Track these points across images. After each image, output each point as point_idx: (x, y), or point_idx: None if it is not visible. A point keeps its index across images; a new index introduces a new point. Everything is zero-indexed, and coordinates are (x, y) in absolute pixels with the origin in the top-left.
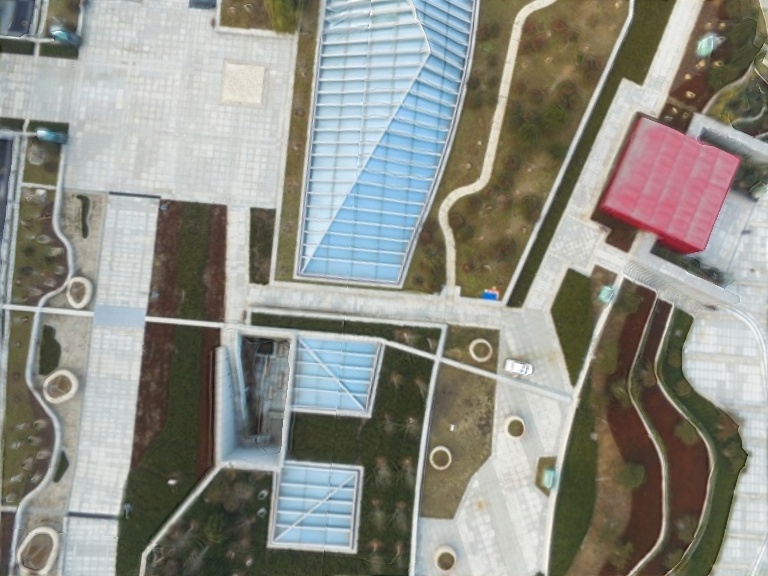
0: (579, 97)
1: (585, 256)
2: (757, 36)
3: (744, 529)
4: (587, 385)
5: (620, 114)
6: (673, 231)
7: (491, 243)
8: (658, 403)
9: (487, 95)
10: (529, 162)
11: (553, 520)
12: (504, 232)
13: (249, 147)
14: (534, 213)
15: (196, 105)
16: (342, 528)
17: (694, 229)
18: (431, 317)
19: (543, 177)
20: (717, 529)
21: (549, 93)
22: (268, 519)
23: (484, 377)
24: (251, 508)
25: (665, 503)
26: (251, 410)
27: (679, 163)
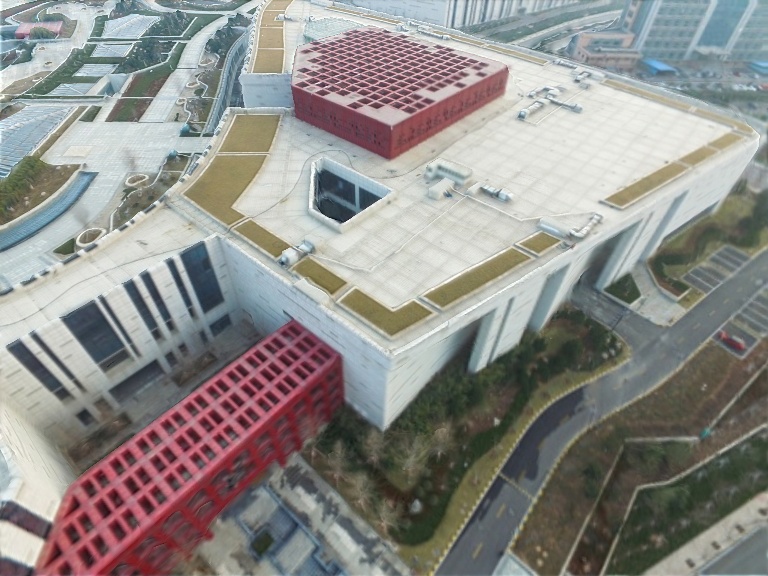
0: None
1: None
2: None
3: None
4: None
5: None
6: None
7: None
8: None
9: None
10: None
11: None
12: None
13: None
14: None
15: None
16: (87, 67)
17: None
18: None
19: None
20: None
21: None
22: None
23: None
24: None
25: None
26: None
27: None
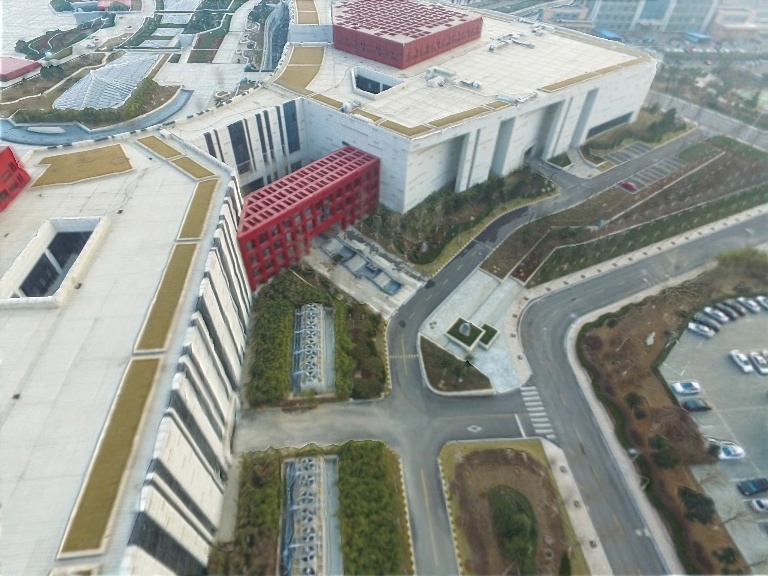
0: None
1: None
2: None
3: None
4: None
5: None
6: None
7: None
8: None
9: None
10: None
11: None
12: None
13: None
14: None
15: None
16: None
17: None
18: None
19: None
20: None
21: None
22: None
23: None
24: None
25: None
26: None
27: None
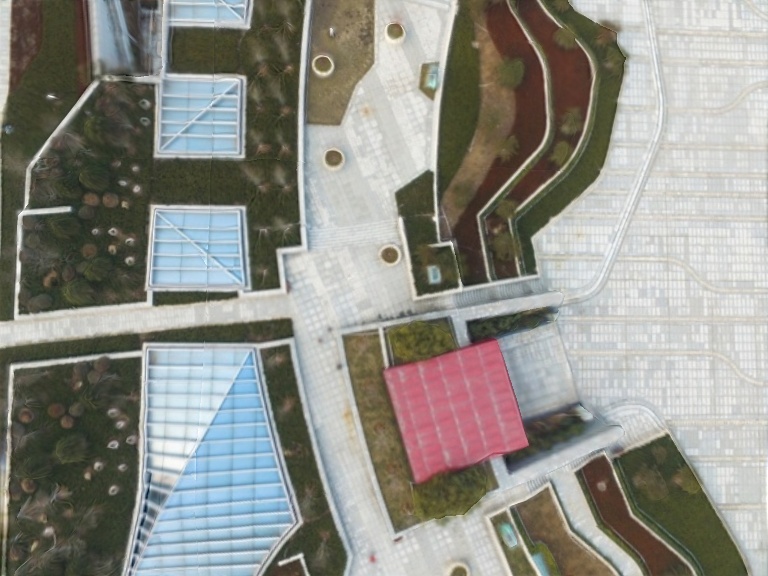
0: None
1: None
2: None
3: (630, 138)
4: None
5: None
6: None
7: None
8: (538, 19)
9: None
10: None
11: (439, 121)
12: None
13: None
14: None
15: None
16: (228, 134)
17: None
18: None
19: None
20: (602, 135)
21: None
22: (153, 131)
23: None
24: (133, 115)
25: (548, 105)
26: (138, 58)
27: None
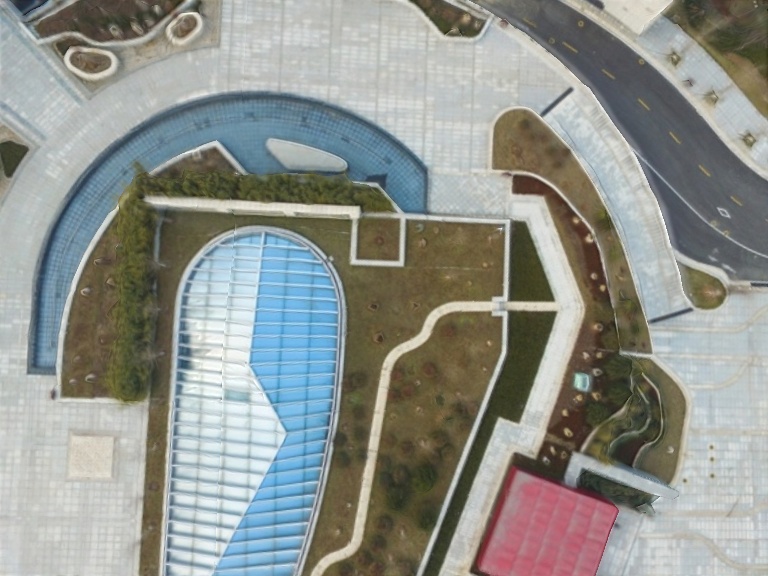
0: (452, 446)
1: None
2: (633, 369)
3: None
4: None
5: (497, 456)
6: None
7: None
8: None
9: (355, 453)
10: (402, 522)
11: None
12: None
13: (100, 526)
14: None
15: (40, 484)
16: None
17: None
18: None
19: (417, 536)
20: None
21: (419, 449)
22: None
23: None
24: None
25: None
26: None
27: (555, 519)
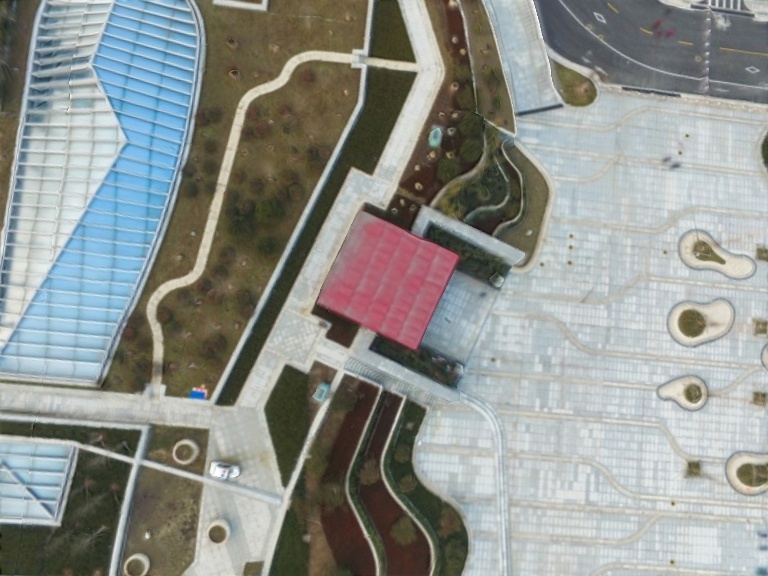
0: (302, 187)
1: (304, 351)
2: (486, 129)
3: None
4: (300, 486)
5: (347, 204)
6: (386, 330)
7: (199, 340)
8: (381, 500)
9: (203, 183)
10: (245, 254)
11: None
12: (209, 330)
13: None
14: (247, 308)
15: None
16: None
17: (408, 328)
18: (134, 417)
19: (260, 270)
20: None
21: (267, 183)
22: None
23: (190, 479)
24: None
25: None
26: None
27: (396, 260)
